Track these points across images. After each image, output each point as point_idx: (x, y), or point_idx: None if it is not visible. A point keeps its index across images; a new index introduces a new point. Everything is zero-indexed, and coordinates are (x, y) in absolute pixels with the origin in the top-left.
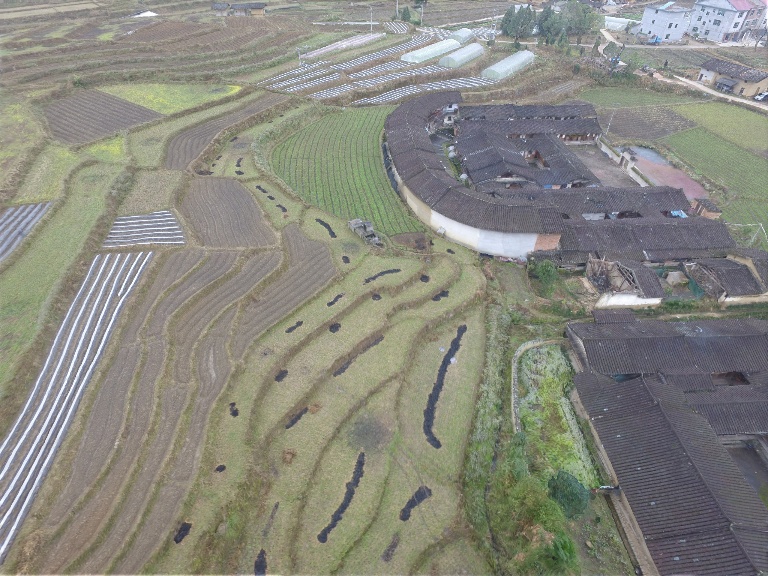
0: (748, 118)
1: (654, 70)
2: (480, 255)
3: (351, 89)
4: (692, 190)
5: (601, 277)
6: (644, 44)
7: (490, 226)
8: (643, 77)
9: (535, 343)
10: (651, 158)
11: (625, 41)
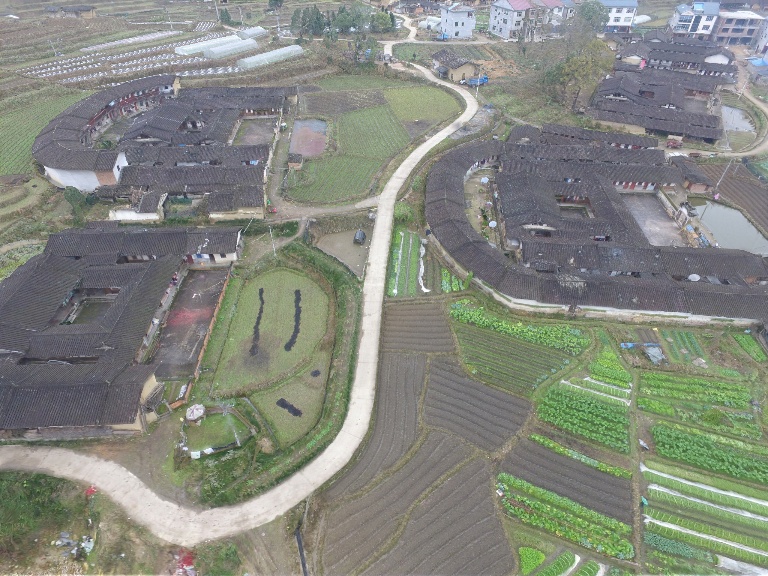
0: (436, 98)
1: (397, 60)
2: (58, 189)
3: (102, 75)
4: (314, 150)
5: (137, 203)
6: (434, 40)
7: (57, 165)
8: (379, 66)
9: (30, 241)
10: (315, 128)
11: (421, 38)
